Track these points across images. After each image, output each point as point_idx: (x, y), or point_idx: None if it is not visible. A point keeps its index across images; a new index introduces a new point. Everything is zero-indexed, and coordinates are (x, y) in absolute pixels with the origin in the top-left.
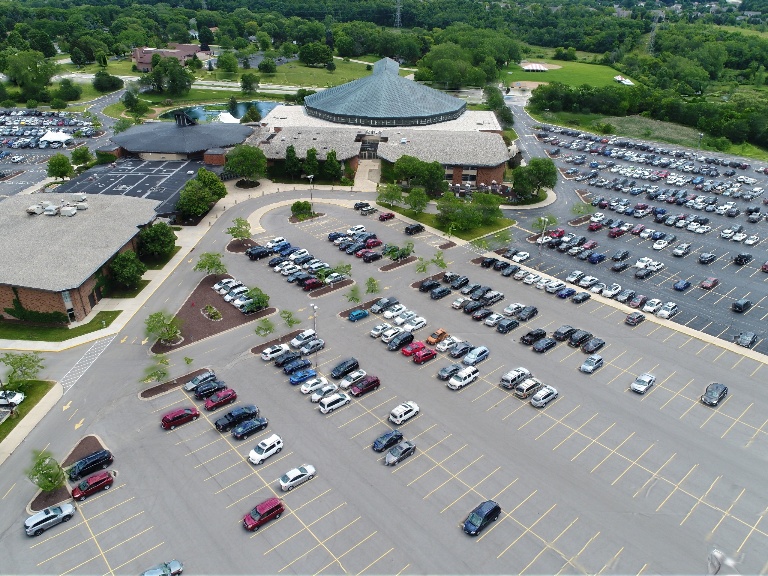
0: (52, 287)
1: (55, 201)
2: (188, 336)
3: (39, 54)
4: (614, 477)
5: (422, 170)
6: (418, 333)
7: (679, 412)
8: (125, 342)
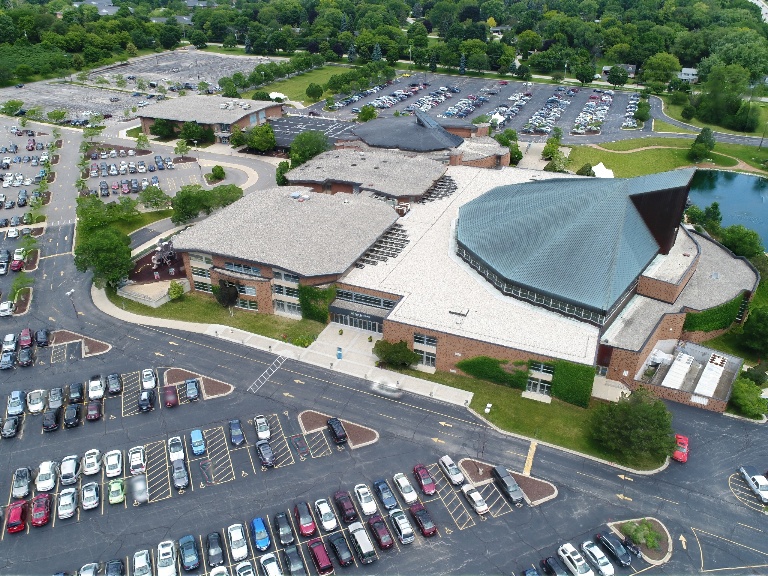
0: (139, 111)
1: (252, 106)
2: None
3: (735, 70)
4: None
5: None
6: (1, 184)
7: None
8: None
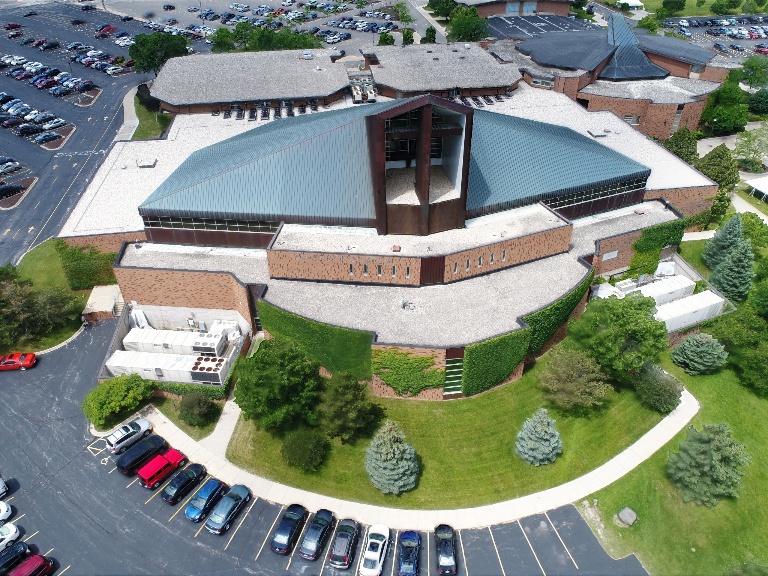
0: None
1: None
2: (384, 8)
3: None
4: (223, 0)
5: (281, 34)
6: None
7: (187, 7)
8: (408, 6)
